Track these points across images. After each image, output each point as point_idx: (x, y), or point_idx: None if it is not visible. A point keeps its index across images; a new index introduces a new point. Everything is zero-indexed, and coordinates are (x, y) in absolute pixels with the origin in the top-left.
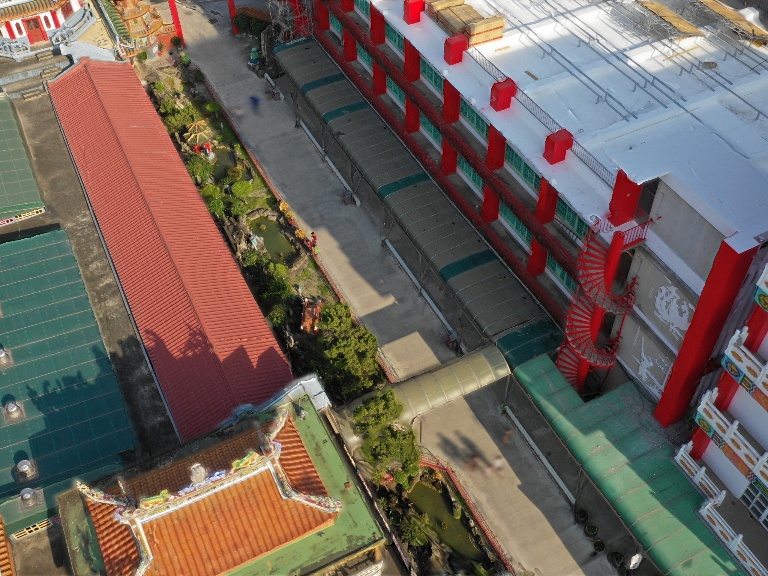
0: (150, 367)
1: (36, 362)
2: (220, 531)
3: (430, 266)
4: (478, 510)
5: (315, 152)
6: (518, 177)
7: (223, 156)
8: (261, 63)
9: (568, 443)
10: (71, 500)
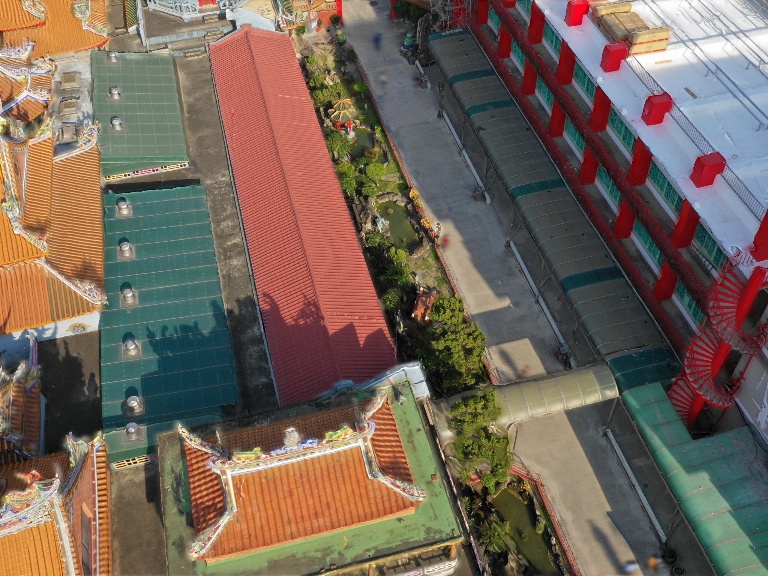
0: (262, 329)
1: (159, 306)
2: (304, 497)
3: (552, 274)
4: (562, 529)
5: (453, 144)
6: (659, 196)
7: (363, 136)
8: (414, 50)
9: (668, 478)
10: (170, 441)
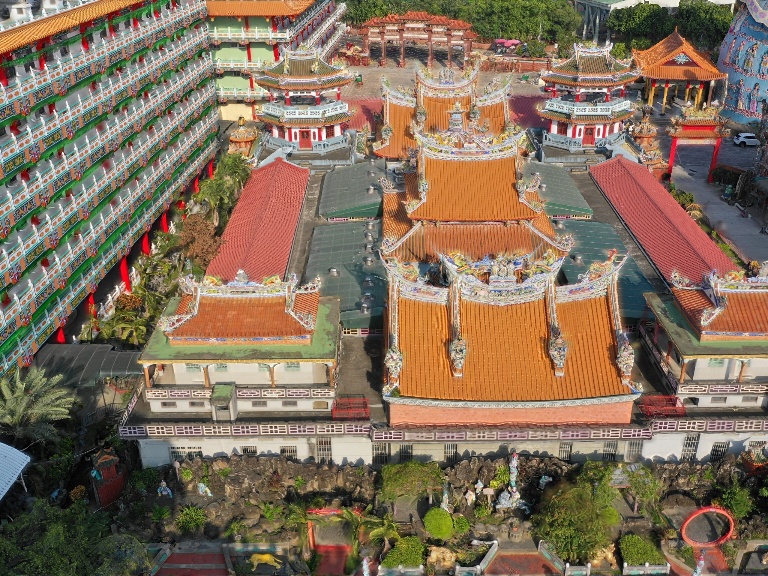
0: None
1: None
2: (767, 312)
3: None
4: None
5: None
6: None
7: None
8: (733, 196)
9: None
10: (652, 296)
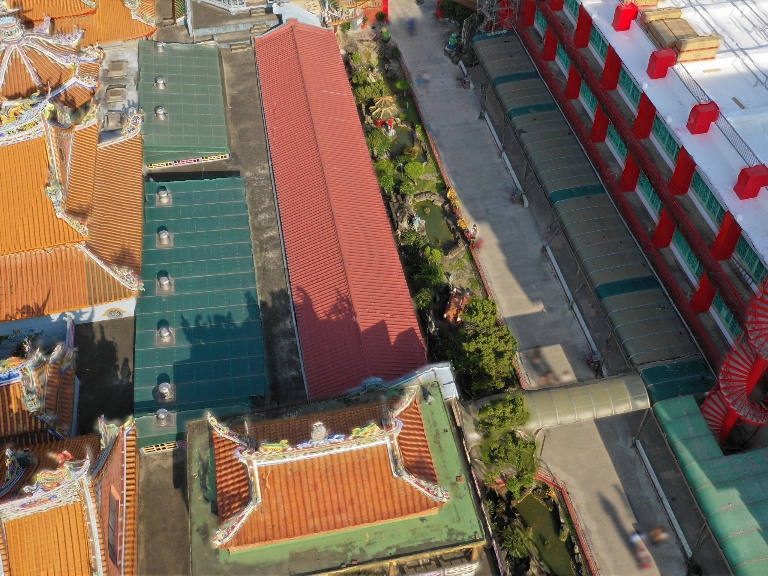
0: (294, 322)
1: (194, 295)
2: (328, 492)
3: (587, 281)
4: (586, 538)
5: (493, 146)
6: (701, 207)
7: (403, 134)
8: (458, 50)
9: (697, 493)
10: (199, 429)
